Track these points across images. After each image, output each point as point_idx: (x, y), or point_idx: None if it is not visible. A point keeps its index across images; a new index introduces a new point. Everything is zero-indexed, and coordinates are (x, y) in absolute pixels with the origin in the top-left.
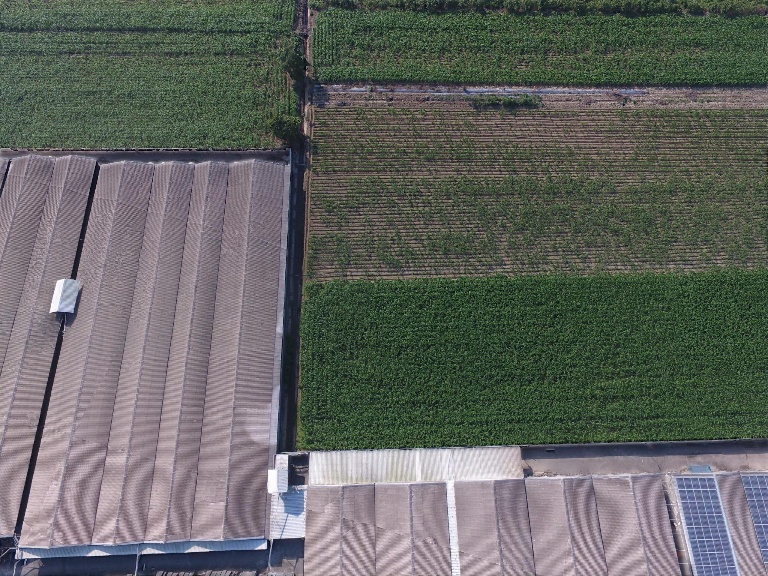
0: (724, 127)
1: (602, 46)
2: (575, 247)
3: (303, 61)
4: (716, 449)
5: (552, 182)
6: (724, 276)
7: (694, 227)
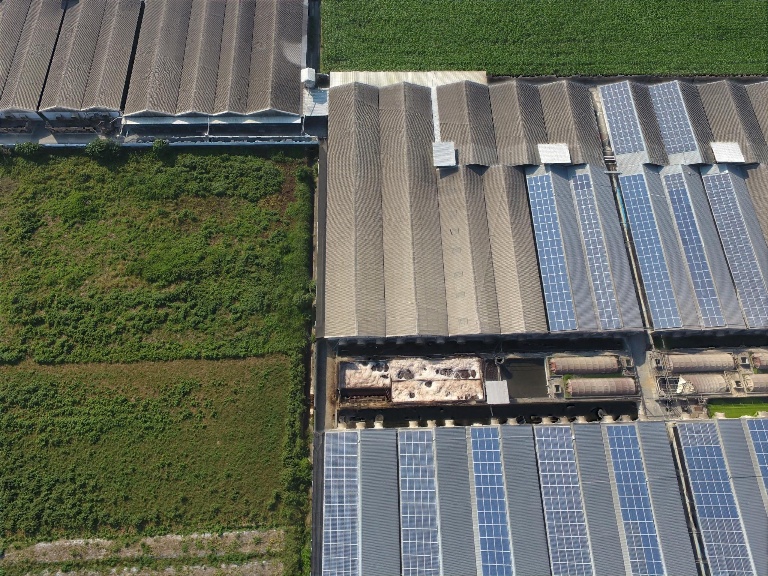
0: None
1: None
2: None
3: None
4: None
5: None
6: None
7: None
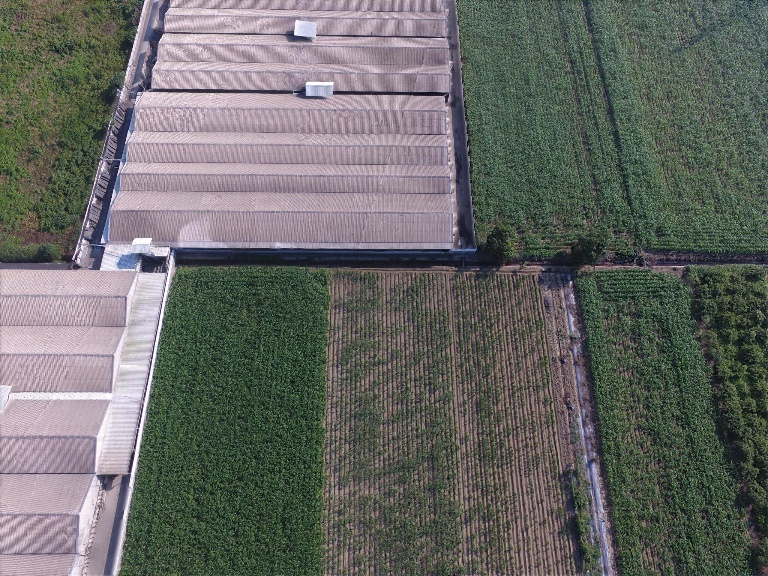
0: None
1: None
2: None
3: (589, 255)
4: None
5: (456, 575)
6: None
7: None
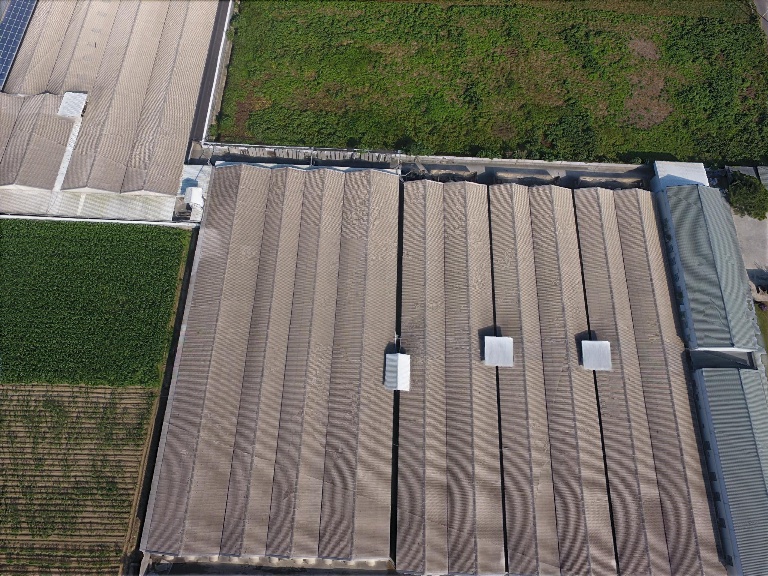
0: None
1: None
2: None
3: None
4: None
5: None
6: None
7: None
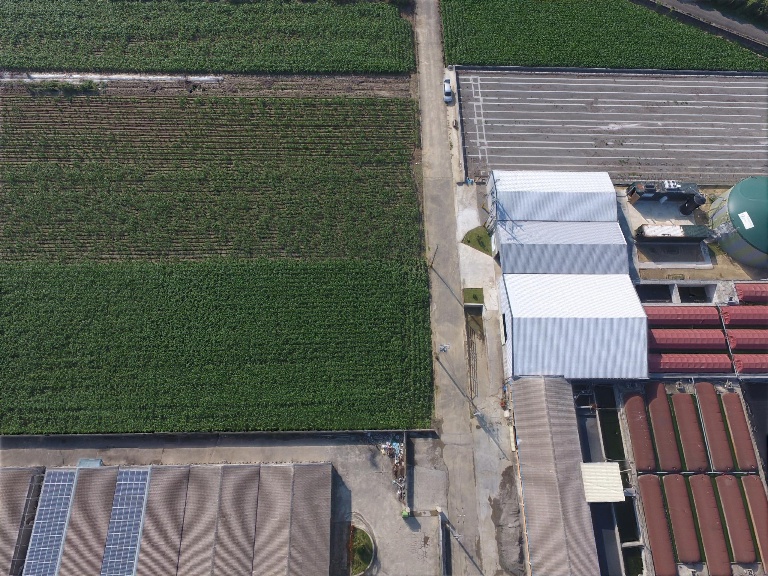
0: (289, 115)
1: (189, 32)
2: (72, 235)
3: None
4: (133, 443)
5: (80, 169)
6: (214, 266)
7: (210, 216)
